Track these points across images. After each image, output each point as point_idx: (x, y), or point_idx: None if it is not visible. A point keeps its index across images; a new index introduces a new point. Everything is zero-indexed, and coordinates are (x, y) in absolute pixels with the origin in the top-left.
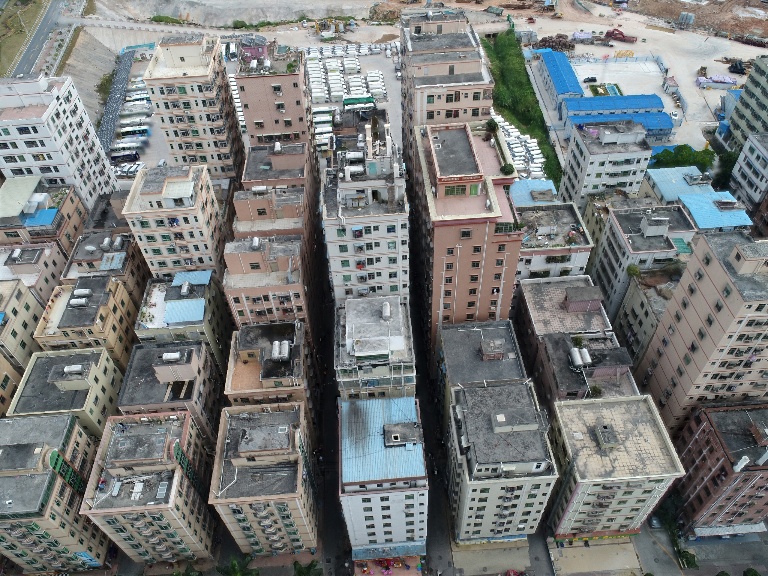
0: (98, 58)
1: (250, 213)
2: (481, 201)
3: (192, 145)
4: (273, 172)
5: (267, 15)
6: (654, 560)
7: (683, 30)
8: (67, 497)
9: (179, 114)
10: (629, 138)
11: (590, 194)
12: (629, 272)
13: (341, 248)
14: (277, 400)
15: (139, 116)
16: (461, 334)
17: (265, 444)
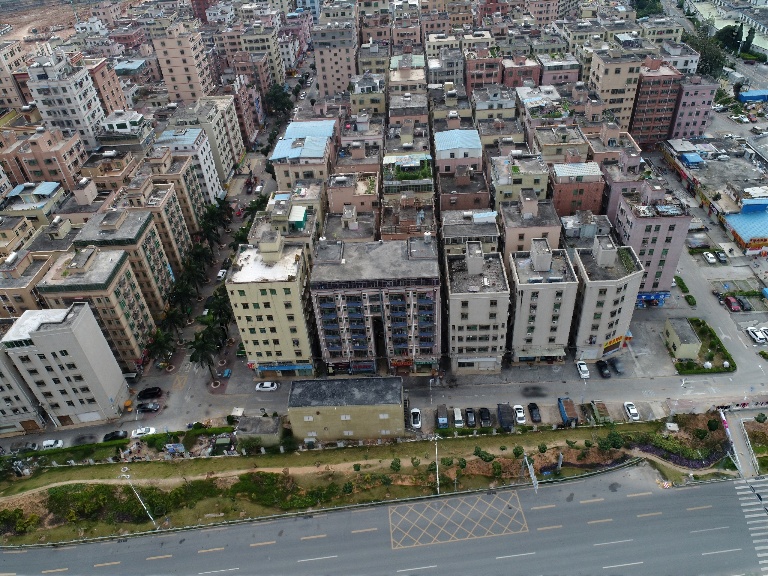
0: None
1: None
2: (89, 65)
3: None
4: None
5: None
6: (257, 156)
7: None
8: None
9: None
10: None
11: None
12: (136, 99)
13: None
14: None
15: None
16: None
17: None
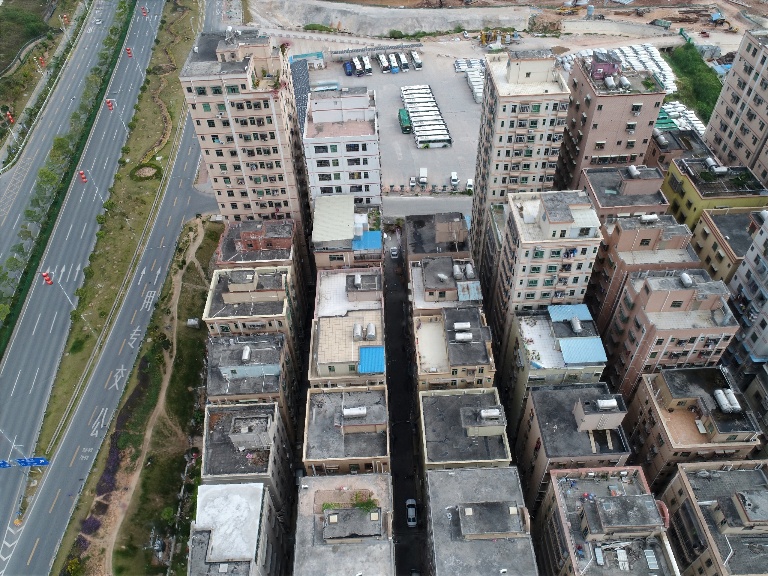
0: None
1: (632, 243)
2: None
3: (519, 166)
4: (624, 197)
5: (422, 25)
6: None
7: None
8: None
9: (522, 133)
10: None
11: None
12: None
13: None
14: (721, 455)
15: None
16: None
17: None
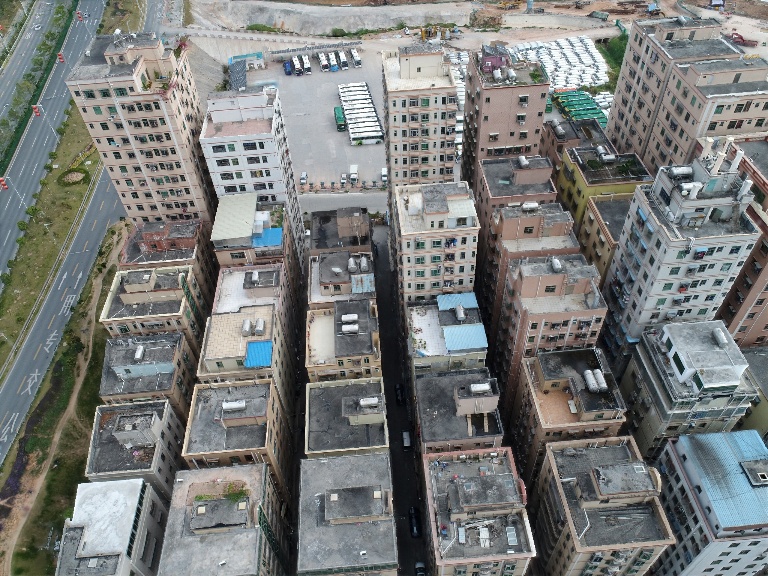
0: (207, 68)
1: (516, 231)
2: None
3: (418, 159)
4: (516, 187)
5: (365, 23)
6: None
7: None
8: None
9: (415, 127)
10: None
11: None
12: None
13: (672, 270)
14: (592, 433)
15: None
16: (760, 359)
17: (627, 485)
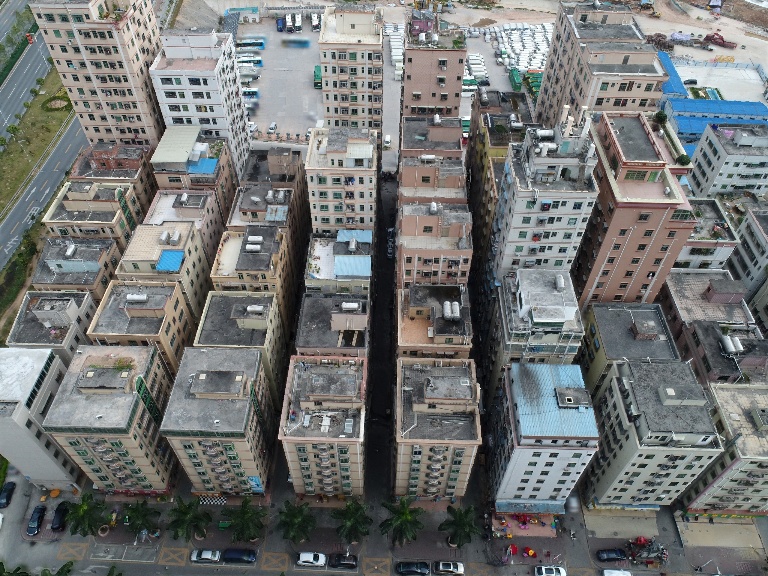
0: (203, 17)
1: (415, 180)
2: (659, 188)
3: (348, 110)
4: (429, 143)
5: None
6: None
7: None
8: (254, 424)
9: (344, 79)
10: (765, 142)
11: (719, 193)
12: None
13: (524, 219)
14: (443, 356)
15: (246, 78)
16: (611, 313)
17: (450, 393)
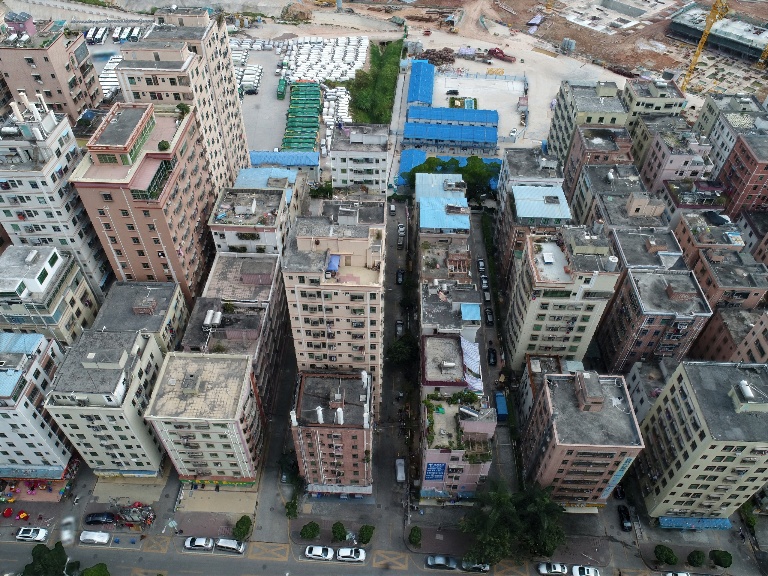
0: None
1: None
2: None
3: None
4: None
5: (186, 5)
6: (270, 509)
7: (565, 55)
8: None
9: None
10: (374, 139)
11: (336, 187)
12: None
13: None
14: None
15: None
16: (132, 291)
17: None
